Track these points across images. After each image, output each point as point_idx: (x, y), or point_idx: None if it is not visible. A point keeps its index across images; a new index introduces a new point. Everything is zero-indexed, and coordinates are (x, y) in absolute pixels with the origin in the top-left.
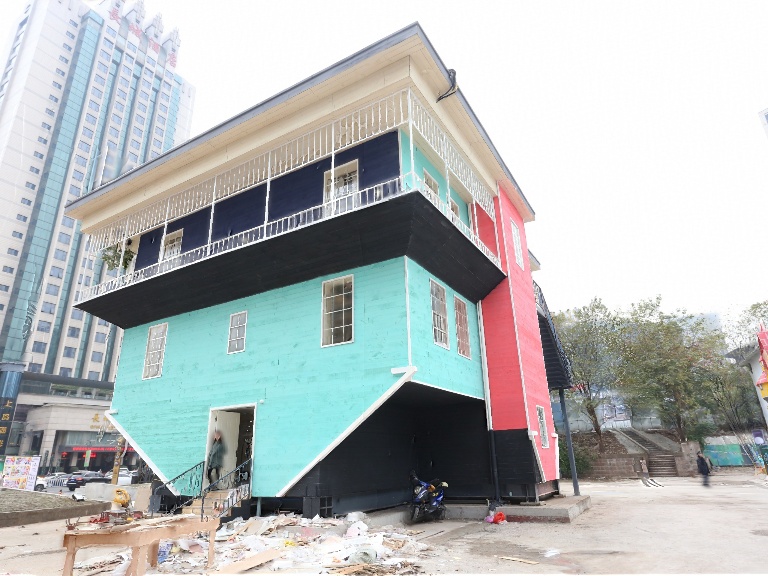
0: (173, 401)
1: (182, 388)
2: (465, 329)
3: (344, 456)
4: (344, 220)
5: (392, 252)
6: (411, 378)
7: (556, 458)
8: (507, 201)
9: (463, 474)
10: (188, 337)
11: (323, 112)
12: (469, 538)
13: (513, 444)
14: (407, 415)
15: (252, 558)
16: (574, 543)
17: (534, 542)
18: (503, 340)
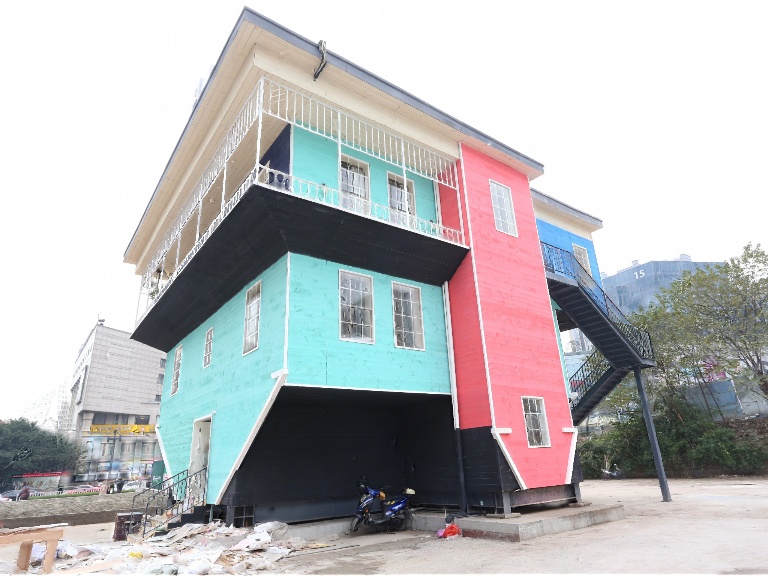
0: (180, 415)
1: (184, 402)
2: (416, 317)
3: (276, 464)
4: (226, 228)
5: (277, 251)
6: (284, 382)
7: (569, 458)
8: (484, 161)
9: (438, 479)
10: (189, 356)
11: (217, 125)
12: (360, 556)
13: (480, 444)
14: (379, 416)
15: (83, 568)
16: (436, 571)
17: (399, 567)
18: (468, 324)
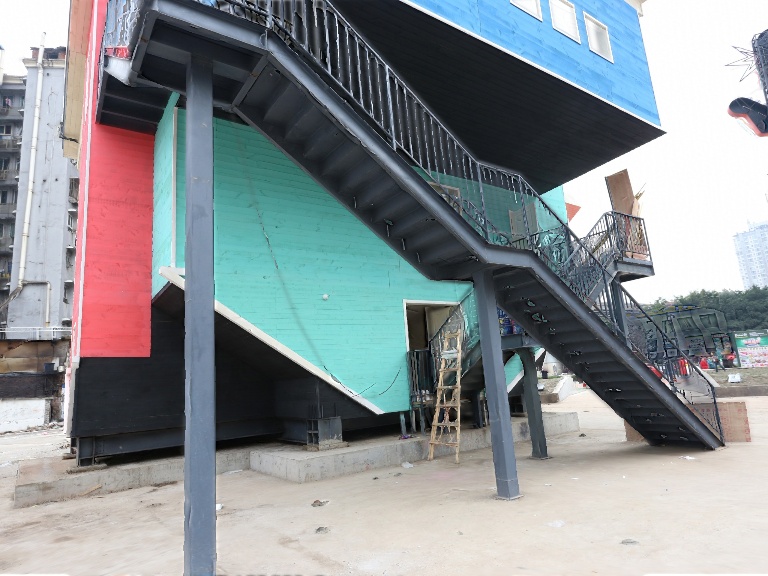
0: None
1: None
2: None
3: None
4: None
5: None
6: None
7: (72, 402)
8: None
9: None
10: None
11: None
12: None
13: None
14: None
15: None
16: None
17: None
18: None
